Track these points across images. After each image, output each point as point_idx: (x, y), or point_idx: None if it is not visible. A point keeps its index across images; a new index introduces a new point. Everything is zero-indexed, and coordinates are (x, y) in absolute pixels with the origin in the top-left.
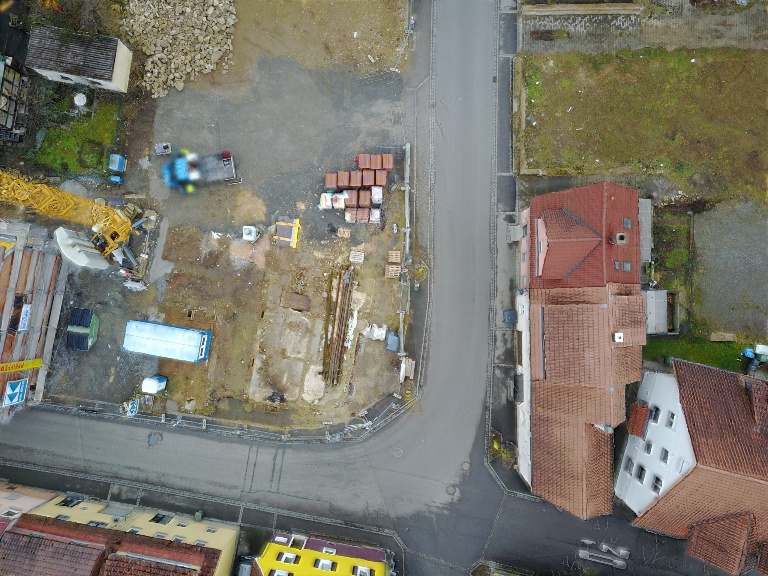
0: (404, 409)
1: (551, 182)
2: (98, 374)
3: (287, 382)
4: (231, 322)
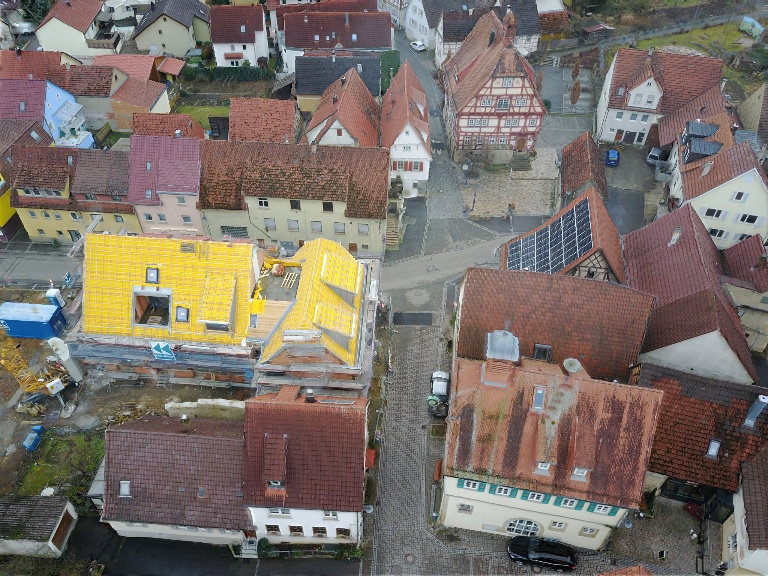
0: None
1: None
2: None
3: None
4: None
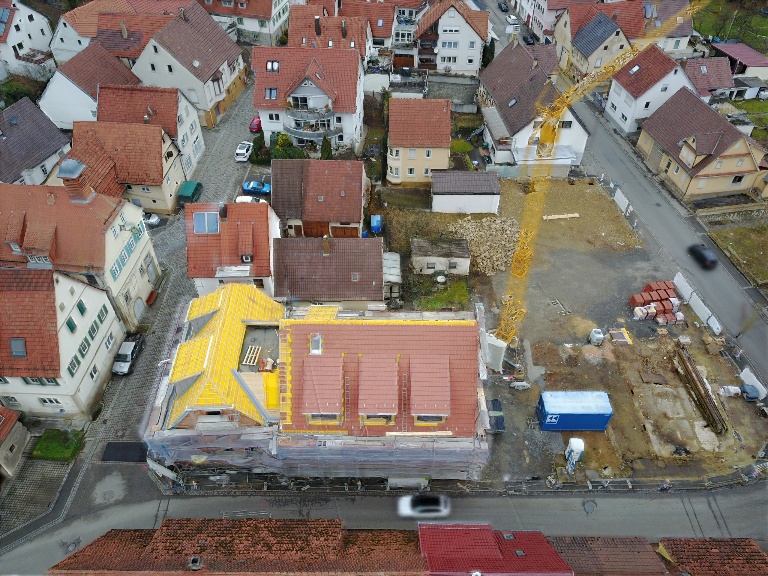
0: None
1: None
2: (514, 458)
3: (682, 438)
4: (609, 401)
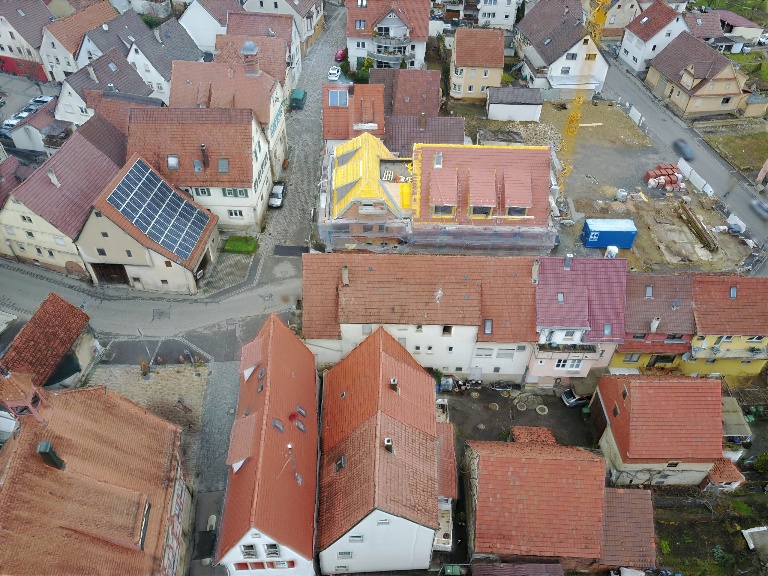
0: (764, 260)
1: (759, 171)
2: None
3: (686, 253)
4: None
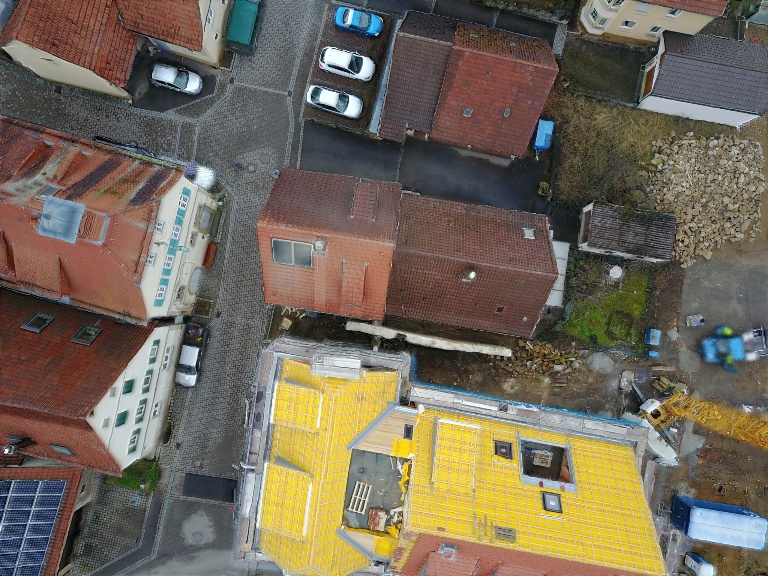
0: None
1: None
2: None
3: None
4: (762, 497)
